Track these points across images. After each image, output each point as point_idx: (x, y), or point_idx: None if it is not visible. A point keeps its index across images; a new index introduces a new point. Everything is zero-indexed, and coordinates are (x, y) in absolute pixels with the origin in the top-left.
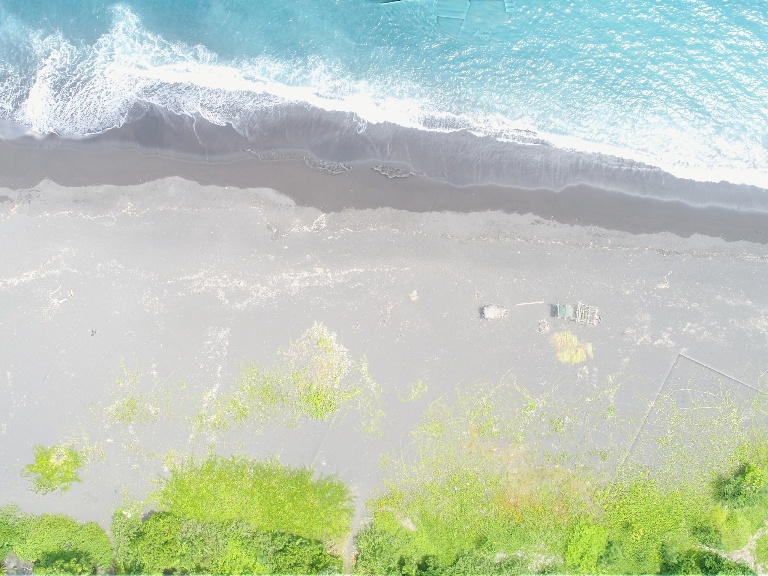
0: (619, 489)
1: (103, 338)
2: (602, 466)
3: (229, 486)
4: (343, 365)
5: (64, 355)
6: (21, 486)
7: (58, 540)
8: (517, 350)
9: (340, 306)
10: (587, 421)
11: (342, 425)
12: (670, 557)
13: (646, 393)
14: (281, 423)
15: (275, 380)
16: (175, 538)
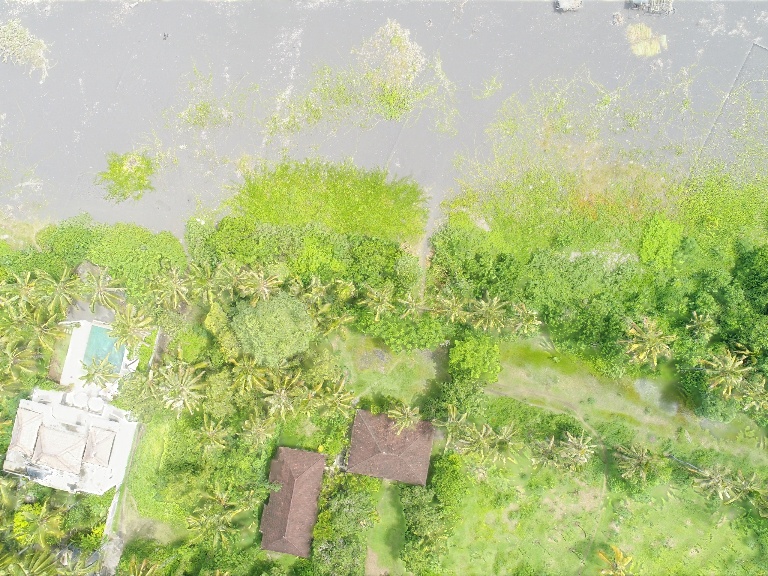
0: (694, 184)
1: (175, 42)
2: (676, 161)
3: (303, 189)
4: (417, 63)
5: (136, 60)
6: (94, 194)
7: (133, 243)
8: (591, 44)
9: (413, 3)
10: (661, 115)
11: (416, 125)
12: (746, 247)
13: (721, 85)
14: (355, 124)
15: (348, 80)
16: (251, 237)
